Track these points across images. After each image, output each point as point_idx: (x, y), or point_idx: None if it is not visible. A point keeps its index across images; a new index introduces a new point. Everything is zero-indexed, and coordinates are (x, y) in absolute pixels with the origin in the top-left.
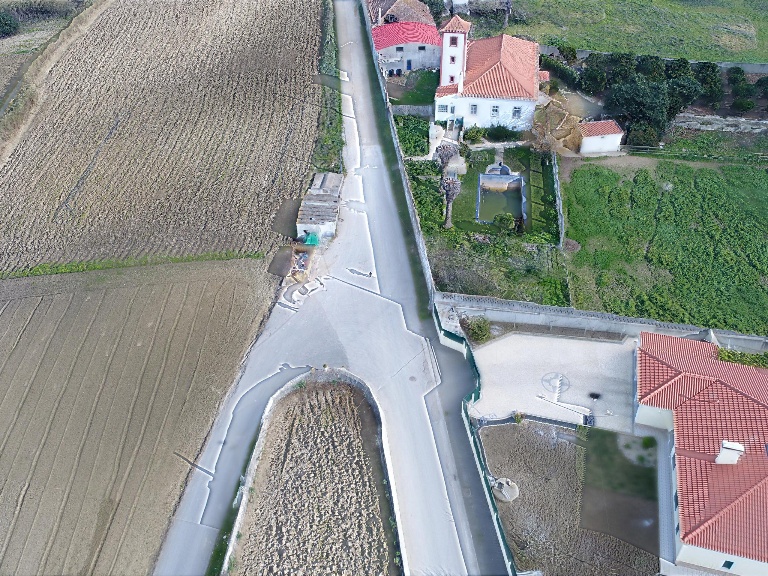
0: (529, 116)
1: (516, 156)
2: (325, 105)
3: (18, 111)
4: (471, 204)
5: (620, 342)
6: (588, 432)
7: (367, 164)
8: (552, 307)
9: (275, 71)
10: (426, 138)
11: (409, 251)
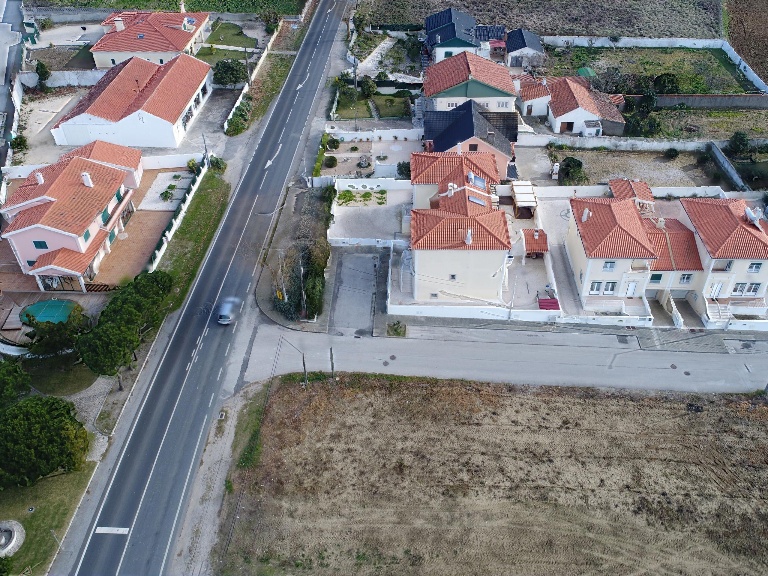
0: None
1: None
2: None
3: None
4: None
5: None
6: (84, 46)
7: None
8: (83, 8)
9: None
10: None
11: None
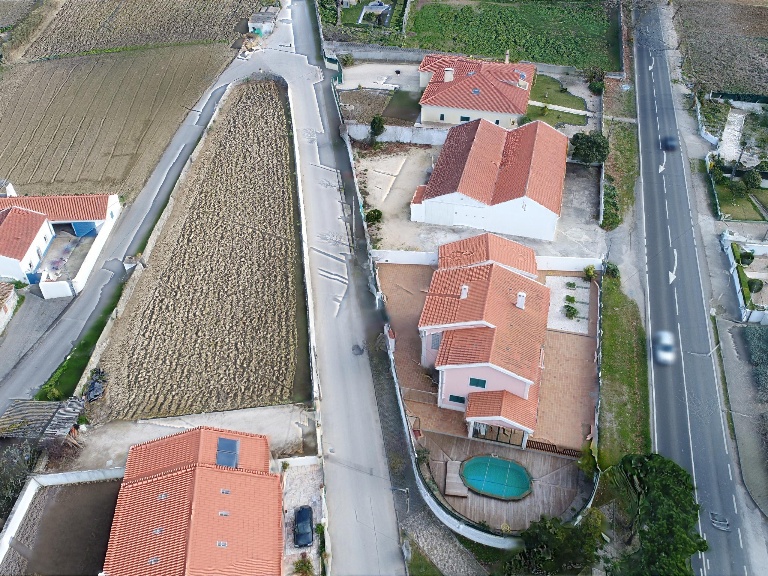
0: None
1: None
2: None
3: None
4: (356, 17)
5: None
6: (395, 92)
7: (295, 4)
8: (387, 47)
9: None
10: None
11: (315, 37)
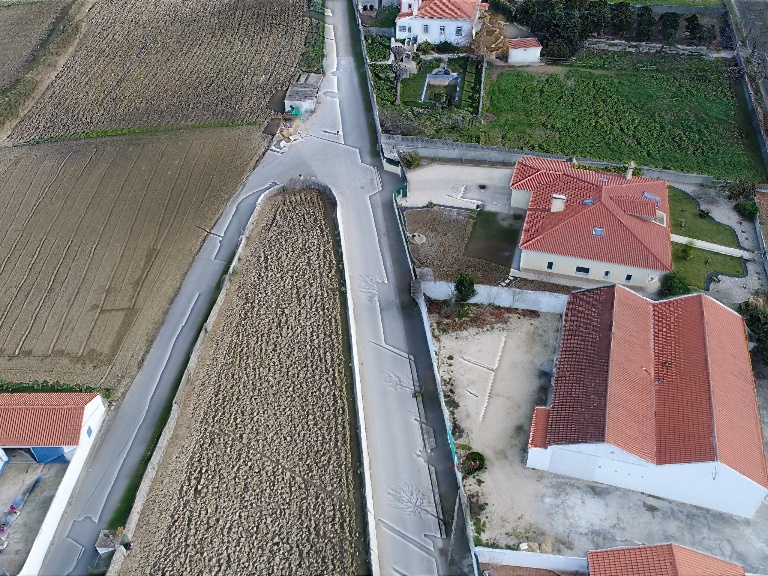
0: (469, 34)
1: (457, 63)
2: (311, 31)
3: (68, 34)
4: (417, 91)
5: (511, 168)
6: (478, 212)
7: (342, 69)
8: (463, 143)
9: (272, 8)
10: (388, 50)
11: (368, 120)
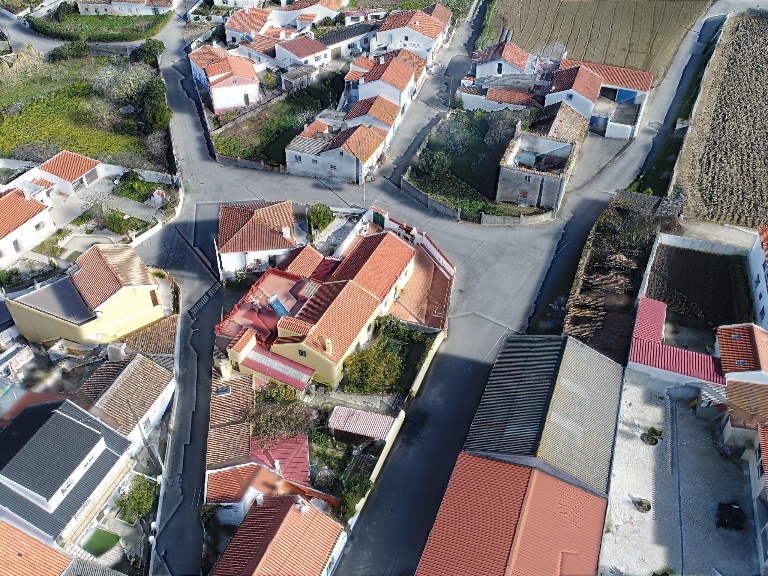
0: None
1: None
2: None
3: None
4: None
5: None
6: None
7: None
8: None
9: None
10: None
11: None
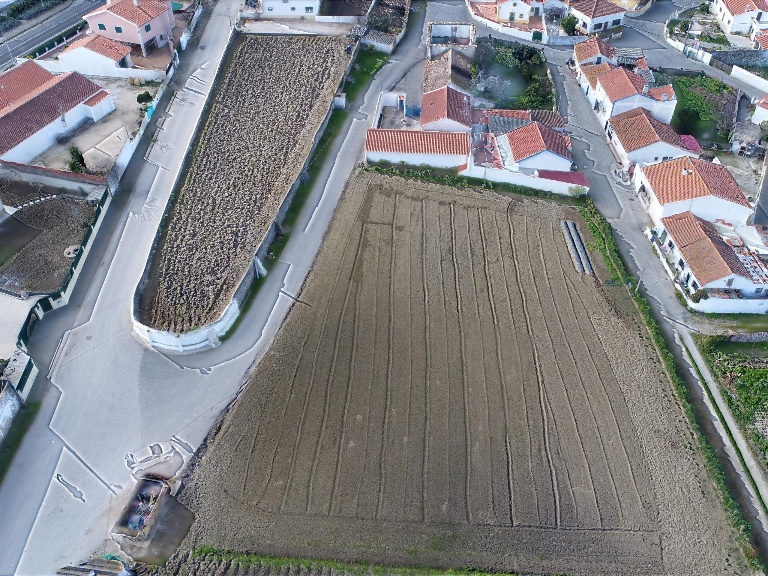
0: None
1: None
2: None
3: None
4: None
5: None
6: None
7: None
8: None
9: None
10: None
11: None
